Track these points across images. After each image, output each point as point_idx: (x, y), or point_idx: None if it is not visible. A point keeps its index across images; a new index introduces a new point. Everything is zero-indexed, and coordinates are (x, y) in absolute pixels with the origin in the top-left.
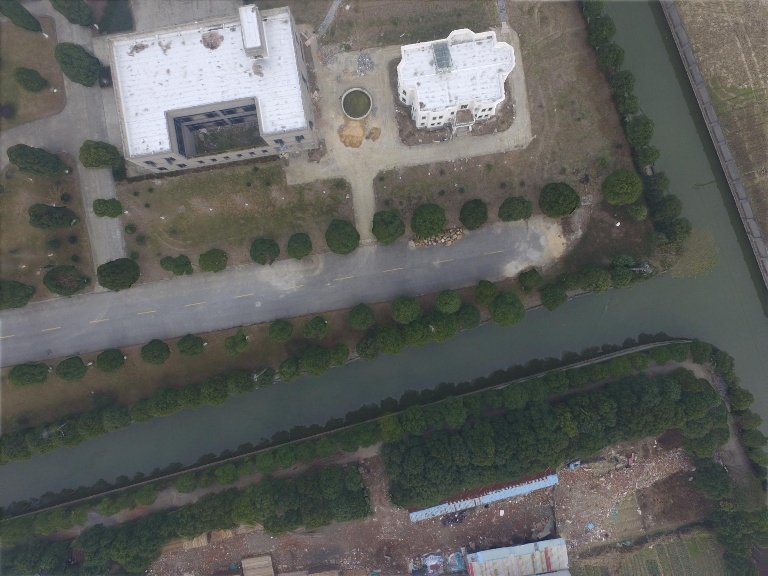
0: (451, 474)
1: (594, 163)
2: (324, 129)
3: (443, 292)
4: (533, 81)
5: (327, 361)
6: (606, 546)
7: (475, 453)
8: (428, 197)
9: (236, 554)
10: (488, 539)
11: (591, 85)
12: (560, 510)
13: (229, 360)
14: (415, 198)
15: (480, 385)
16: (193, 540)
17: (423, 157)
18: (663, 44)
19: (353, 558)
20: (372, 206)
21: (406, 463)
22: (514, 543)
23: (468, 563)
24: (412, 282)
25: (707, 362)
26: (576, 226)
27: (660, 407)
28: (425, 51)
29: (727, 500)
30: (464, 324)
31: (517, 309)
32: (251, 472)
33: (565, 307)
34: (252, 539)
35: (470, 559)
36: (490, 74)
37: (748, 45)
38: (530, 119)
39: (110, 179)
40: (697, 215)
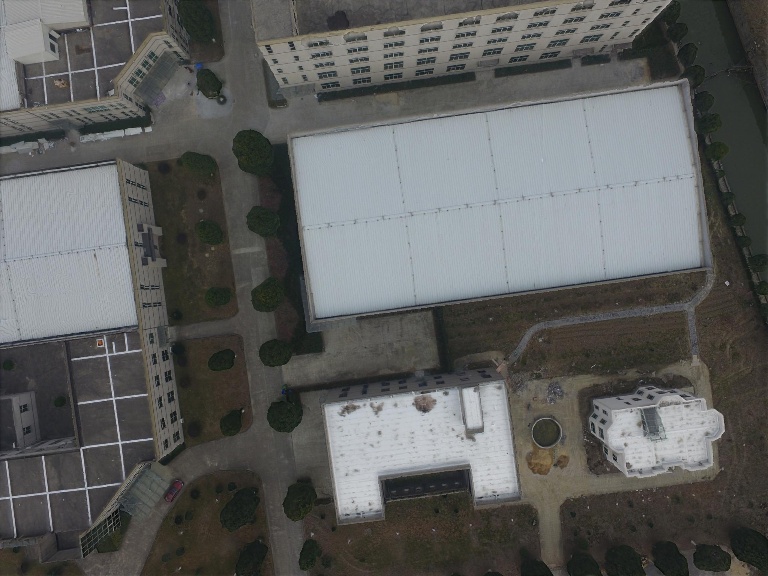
0: None
1: None
2: None
3: None
4: None
5: None
6: None
7: None
8: (615, 527)
9: None
10: None
11: None
12: None
13: None
14: (602, 527)
15: None
16: None
17: (611, 486)
18: None
19: None
20: (558, 532)
21: None
22: None
23: None
24: None
25: None
26: None
27: None
28: (633, 412)
29: None
30: None
31: None
32: None
33: None
34: None
35: None
36: (697, 437)
37: None
38: (718, 451)
39: None
40: None
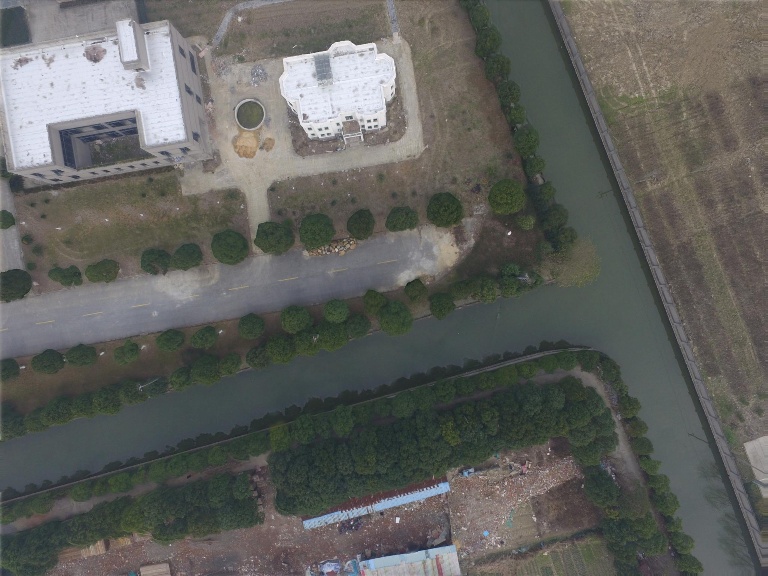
0: (334, 483)
1: (485, 172)
2: (218, 140)
3: (328, 302)
4: (424, 91)
5: (217, 370)
6: (502, 553)
7: (357, 462)
8: (321, 207)
9: (135, 562)
10: (384, 546)
11: (482, 95)
12: (455, 517)
13: (126, 369)
14: (308, 208)
15: (379, 393)
16: (90, 548)
17: (316, 167)
18: (559, 53)
19: (251, 565)
20: (267, 216)
21: (289, 472)
22: (409, 550)
23: (360, 570)
24: (307, 291)
25: (594, 370)
26: (469, 235)
27: (540, 416)
28: (308, 63)
29: (612, 508)
30: (352, 333)
31: (402, 319)
32: (144, 481)
33: (455, 316)
34: (151, 547)
35: (362, 566)
36: (372, 85)
37: (639, 54)
38: (422, 129)
39: (8, 190)
40: (580, 224)
